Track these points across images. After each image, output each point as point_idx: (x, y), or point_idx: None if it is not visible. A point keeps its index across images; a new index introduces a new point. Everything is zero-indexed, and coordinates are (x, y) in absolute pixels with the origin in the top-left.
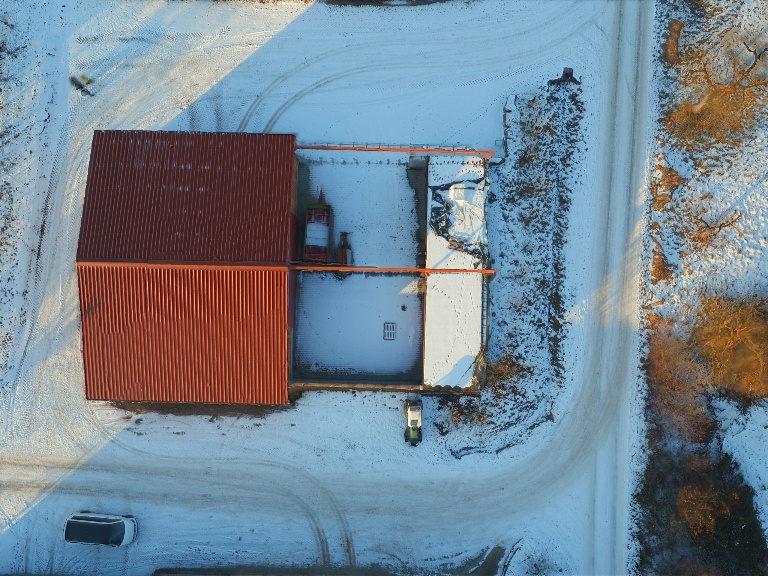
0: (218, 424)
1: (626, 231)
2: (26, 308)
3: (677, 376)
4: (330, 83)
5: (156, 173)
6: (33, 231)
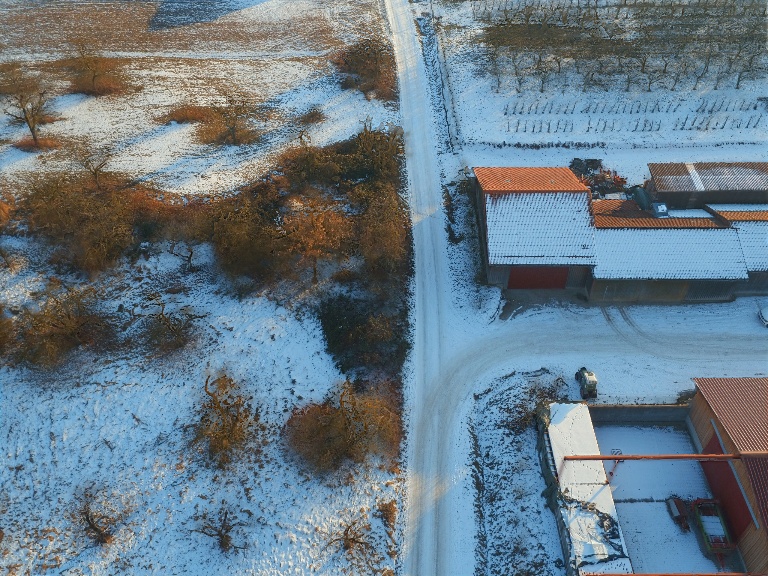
0: None
1: (420, 548)
2: None
3: (378, 426)
4: None
5: None
6: None
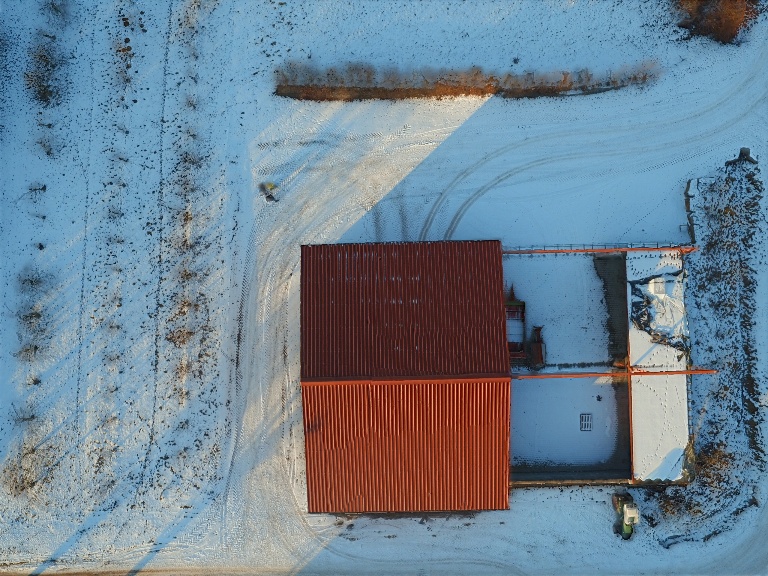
0: (428, 526)
1: None
2: (230, 419)
3: None
4: (512, 177)
5: (368, 287)
6: (230, 341)
